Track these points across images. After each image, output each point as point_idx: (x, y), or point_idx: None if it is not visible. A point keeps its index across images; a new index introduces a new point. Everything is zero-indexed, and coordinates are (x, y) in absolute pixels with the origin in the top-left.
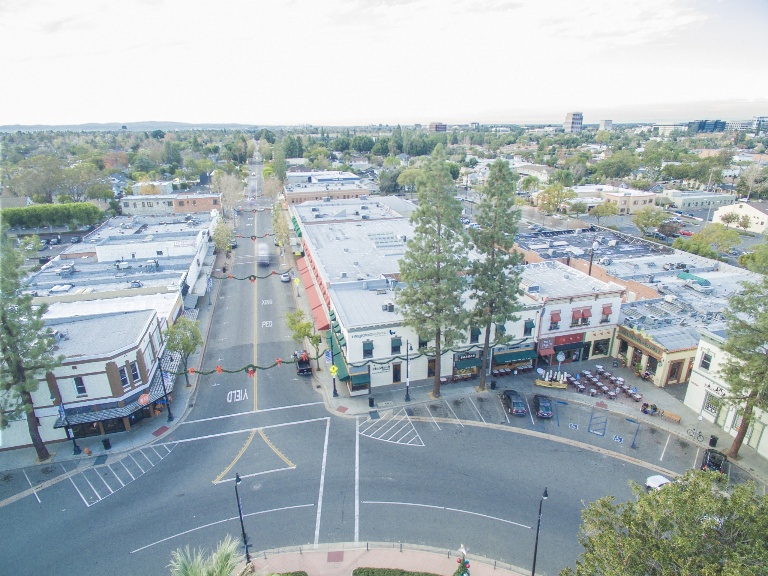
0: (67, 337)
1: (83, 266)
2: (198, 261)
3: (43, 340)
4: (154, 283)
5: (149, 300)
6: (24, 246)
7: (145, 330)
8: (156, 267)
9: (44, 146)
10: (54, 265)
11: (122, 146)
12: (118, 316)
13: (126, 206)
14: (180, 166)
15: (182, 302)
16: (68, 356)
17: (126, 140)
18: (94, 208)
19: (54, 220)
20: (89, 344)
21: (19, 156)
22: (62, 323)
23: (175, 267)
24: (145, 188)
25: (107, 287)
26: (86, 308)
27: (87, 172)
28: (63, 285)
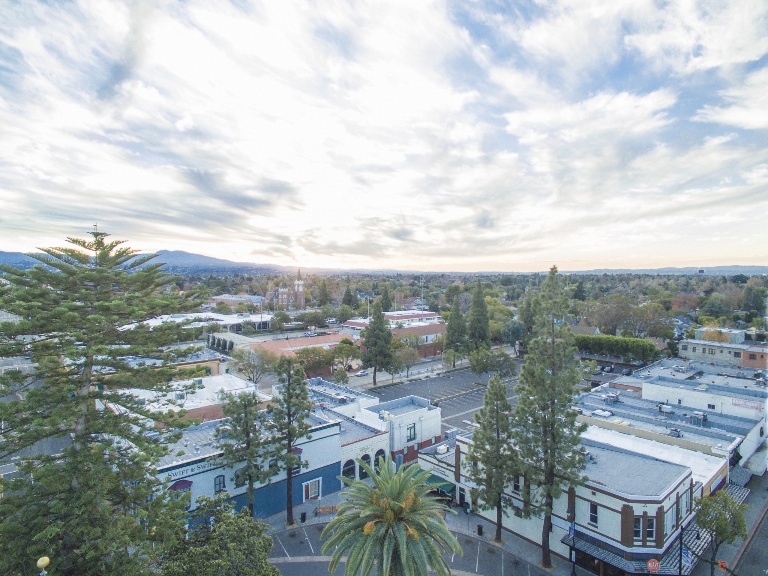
0: (595, 461)
1: (627, 398)
2: (761, 429)
3: (576, 456)
4: (696, 438)
5: (686, 455)
6: (583, 368)
7: (673, 487)
8: (703, 421)
9: (621, 286)
10: (602, 390)
11: (694, 289)
12: (648, 460)
13: (684, 349)
14: (760, 314)
15: (727, 472)
16: (591, 479)
17: (700, 284)
18: (651, 346)
19: (613, 350)
20: (613, 476)
21: (600, 293)
22: (595, 446)
23: (727, 428)
24: (710, 334)
25: (644, 426)
26: (619, 440)
27: (653, 312)
28: (605, 411)
